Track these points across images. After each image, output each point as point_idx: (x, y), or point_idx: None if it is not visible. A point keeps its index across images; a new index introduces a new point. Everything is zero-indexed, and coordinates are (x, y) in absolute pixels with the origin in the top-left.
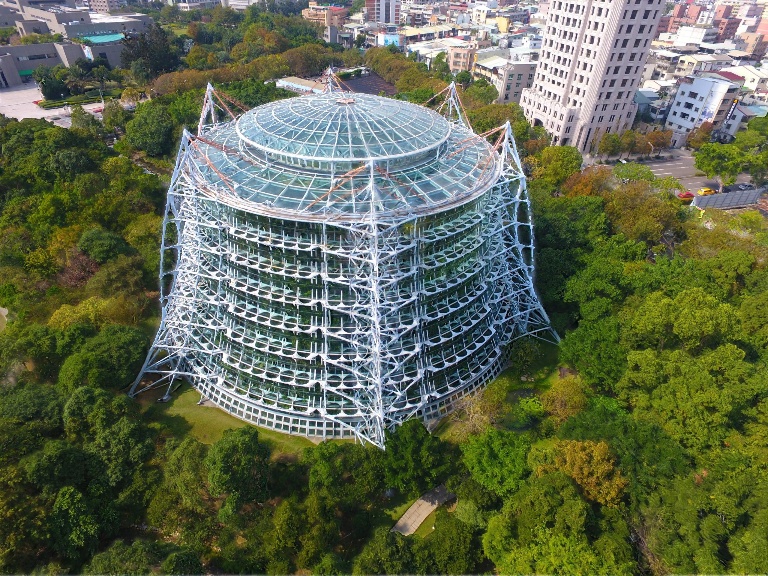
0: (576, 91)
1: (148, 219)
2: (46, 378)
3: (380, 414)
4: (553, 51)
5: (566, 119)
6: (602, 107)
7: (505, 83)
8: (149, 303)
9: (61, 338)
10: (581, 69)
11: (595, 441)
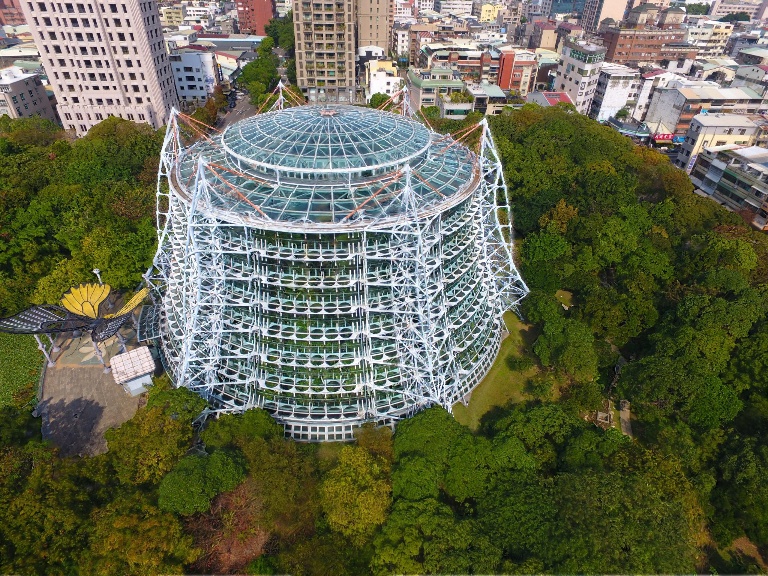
0: (133, 89)
1: (133, 432)
2: (460, 518)
3: (519, 277)
4: (67, 57)
5: (149, 117)
6: (165, 96)
7: (14, 108)
8: (315, 447)
9: (420, 489)
10: (125, 67)
11: (538, 214)
